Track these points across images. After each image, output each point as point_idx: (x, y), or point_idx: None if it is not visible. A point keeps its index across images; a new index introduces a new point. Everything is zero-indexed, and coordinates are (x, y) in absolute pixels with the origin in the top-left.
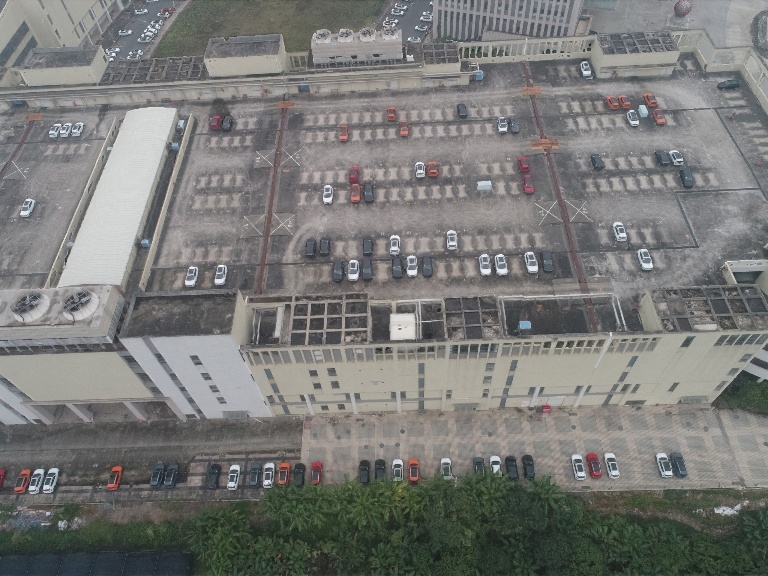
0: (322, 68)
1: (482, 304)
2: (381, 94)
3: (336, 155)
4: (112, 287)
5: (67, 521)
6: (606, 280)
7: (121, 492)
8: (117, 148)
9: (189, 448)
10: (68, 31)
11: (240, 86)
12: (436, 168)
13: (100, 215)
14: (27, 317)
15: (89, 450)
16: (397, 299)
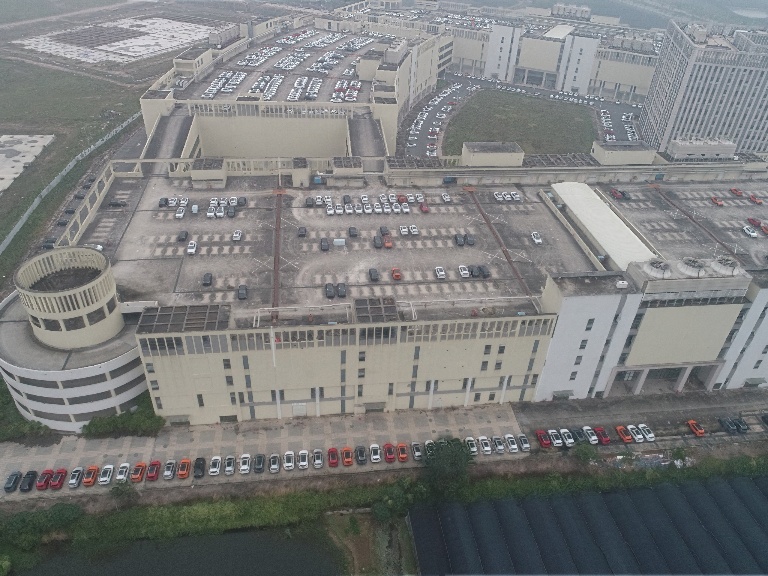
0: (679, 162)
1: None
2: (714, 182)
3: (724, 213)
4: None
5: (682, 459)
6: None
7: (707, 438)
8: (572, 204)
9: (731, 408)
10: None
11: (620, 173)
12: None
13: (612, 239)
14: (699, 272)
15: (653, 413)
16: None
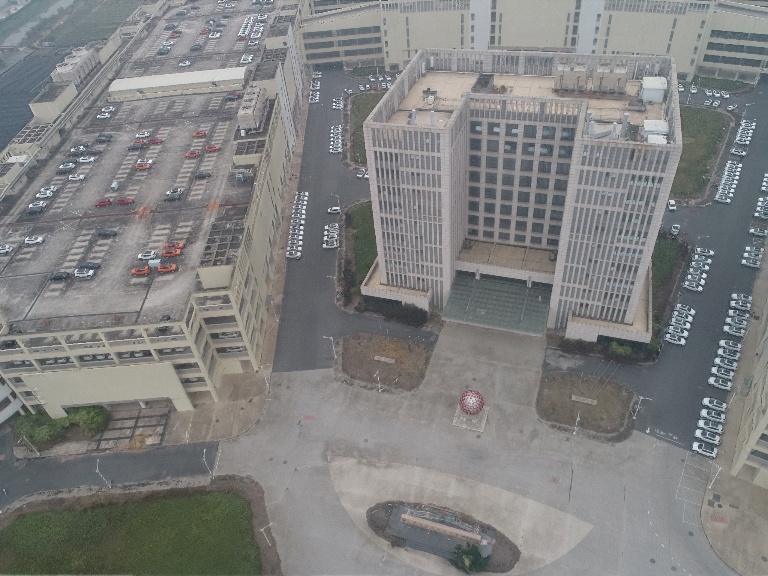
0: None
1: (2, 174)
2: None
3: (182, 135)
4: (71, 73)
5: None
6: (3, 235)
7: None
8: None
9: None
10: (401, 48)
11: None
12: (139, 166)
13: None
14: None
15: None
16: (50, 165)
